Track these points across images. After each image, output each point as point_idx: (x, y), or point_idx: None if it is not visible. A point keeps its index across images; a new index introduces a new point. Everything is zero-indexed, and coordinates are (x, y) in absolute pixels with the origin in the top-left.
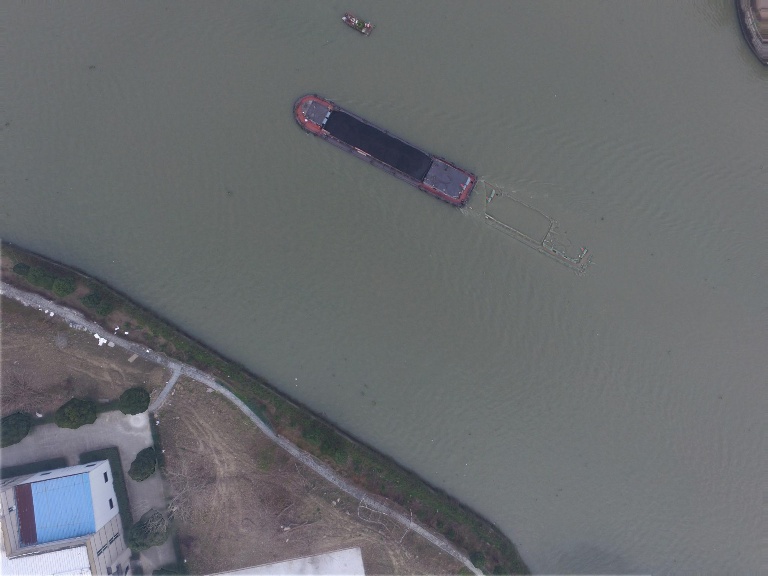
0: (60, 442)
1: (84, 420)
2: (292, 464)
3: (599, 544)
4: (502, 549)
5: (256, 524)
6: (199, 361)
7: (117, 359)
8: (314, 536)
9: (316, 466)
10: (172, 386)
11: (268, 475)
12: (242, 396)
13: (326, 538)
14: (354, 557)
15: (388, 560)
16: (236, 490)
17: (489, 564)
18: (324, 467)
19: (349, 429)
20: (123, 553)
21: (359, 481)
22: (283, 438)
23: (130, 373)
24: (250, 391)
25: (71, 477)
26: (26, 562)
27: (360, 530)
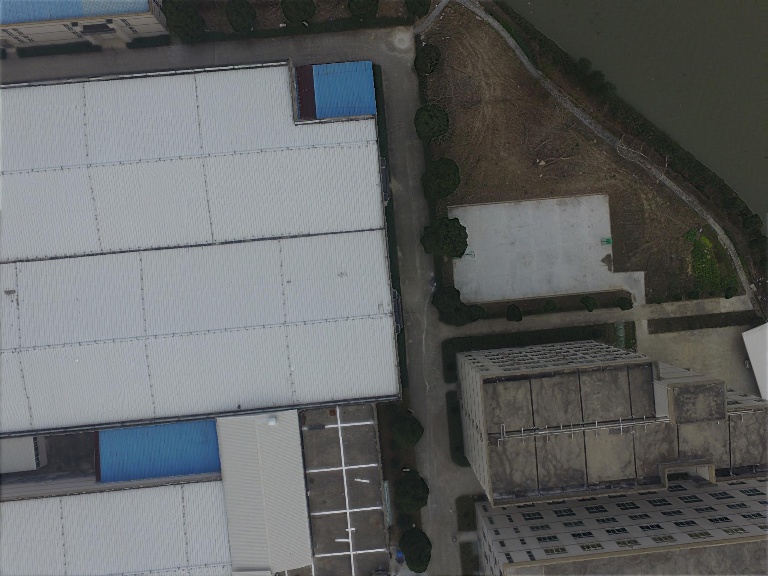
0: (323, 55)
1: (375, 4)
2: (551, 102)
3: None
4: (745, 211)
5: (517, 150)
6: None
7: None
8: (570, 171)
9: (574, 108)
10: (441, 10)
11: (532, 104)
12: (511, 26)
13: (582, 174)
14: (601, 203)
15: (638, 205)
16: (502, 113)
17: None
18: (581, 110)
19: None
20: None
21: None
22: (545, 76)
23: None
24: (517, 25)
25: (354, 63)
26: (312, 129)
27: (615, 171)
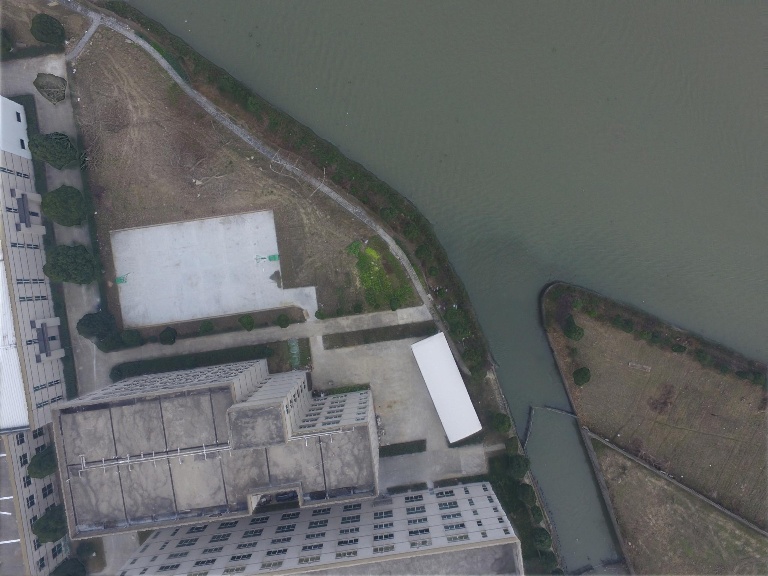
0: None
1: None
2: (208, 121)
3: None
4: (416, 220)
5: (167, 171)
6: (120, 13)
7: (36, 1)
8: (225, 189)
9: (232, 125)
10: (91, 35)
11: (182, 124)
12: (160, 48)
13: (237, 192)
14: (266, 220)
15: (299, 219)
16: (148, 135)
17: (403, 235)
18: (240, 127)
19: (270, 100)
20: (32, 193)
21: (274, 141)
22: (200, 95)
23: (48, 14)
24: (169, 46)
25: None
26: None
27: (272, 186)
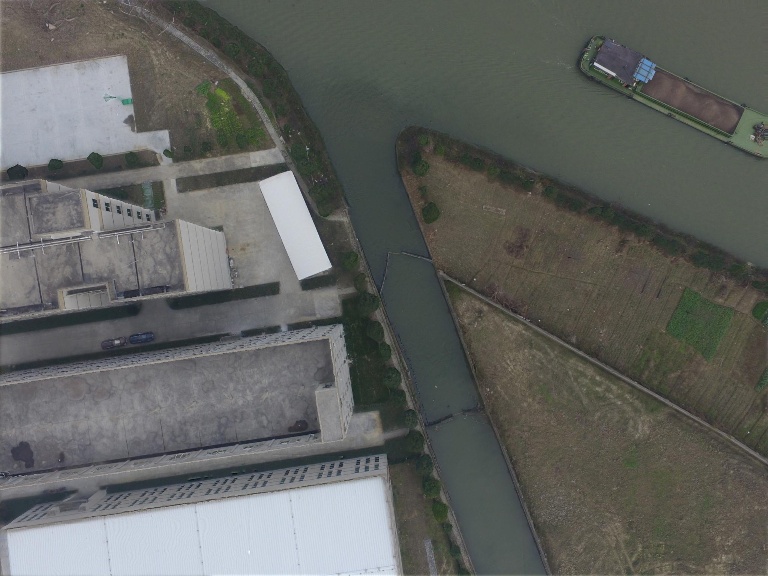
0: None
1: None
2: None
3: (371, 74)
4: (267, 63)
5: (19, 14)
6: None
7: None
8: (77, 32)
9: None
10: None
11: None
12: None
13: (89, 35)
14: (120, 65)
15: (150, 61)
16: None
17: None
18: None
19: None
20: None
21: None
22: None
23: None
24: None
25: None
26: None
27: (123, 28)
